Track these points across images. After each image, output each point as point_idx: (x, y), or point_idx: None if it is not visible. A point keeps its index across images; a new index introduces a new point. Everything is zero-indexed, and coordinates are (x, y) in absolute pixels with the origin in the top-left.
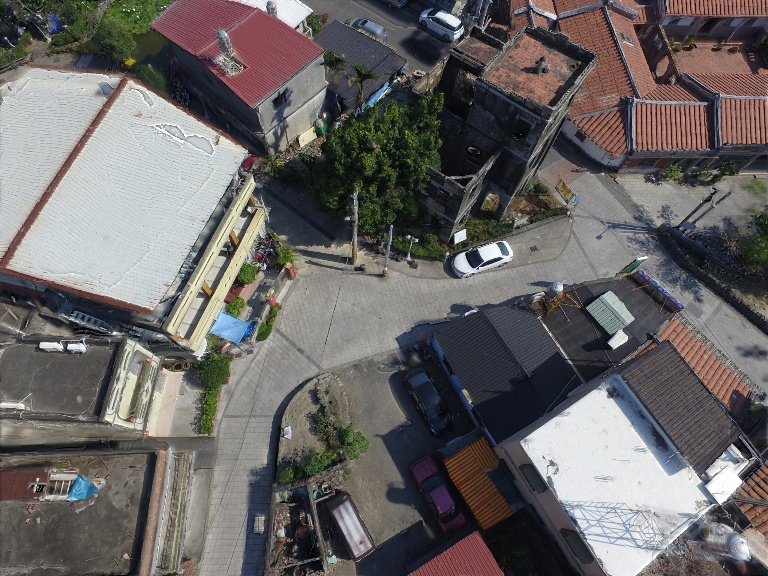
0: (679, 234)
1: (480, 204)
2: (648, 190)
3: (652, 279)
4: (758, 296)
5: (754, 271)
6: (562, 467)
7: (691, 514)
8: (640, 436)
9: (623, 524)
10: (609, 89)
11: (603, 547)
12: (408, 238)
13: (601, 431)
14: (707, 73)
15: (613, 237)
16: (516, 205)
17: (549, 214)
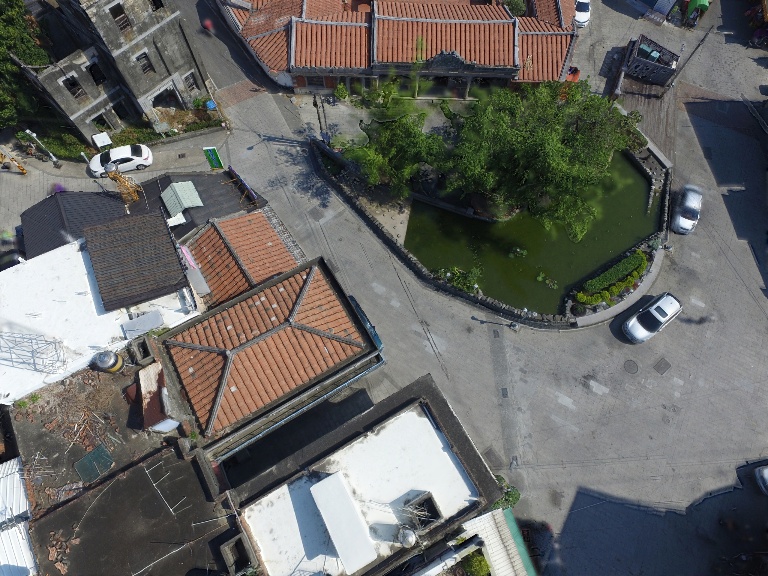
0: (324, 146)
1: (139, 114)
2: (321, 110)
3: (236, 173)
4: (383, 204)
5: (387, 182)
6: (1, 304)
7: (101, 347)
8: (89, 283)
9: (32, 352)
10: (285, 12)
11: (3, 369)
12: (28, 133)
13: (54, 277)
14: (397, 2)
15: (264, 148)
16: (181, 118)
17: (202, 125)
